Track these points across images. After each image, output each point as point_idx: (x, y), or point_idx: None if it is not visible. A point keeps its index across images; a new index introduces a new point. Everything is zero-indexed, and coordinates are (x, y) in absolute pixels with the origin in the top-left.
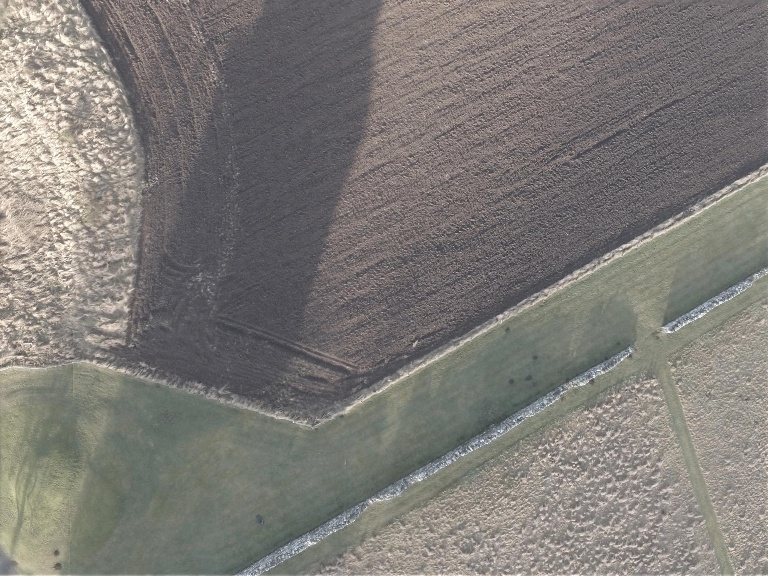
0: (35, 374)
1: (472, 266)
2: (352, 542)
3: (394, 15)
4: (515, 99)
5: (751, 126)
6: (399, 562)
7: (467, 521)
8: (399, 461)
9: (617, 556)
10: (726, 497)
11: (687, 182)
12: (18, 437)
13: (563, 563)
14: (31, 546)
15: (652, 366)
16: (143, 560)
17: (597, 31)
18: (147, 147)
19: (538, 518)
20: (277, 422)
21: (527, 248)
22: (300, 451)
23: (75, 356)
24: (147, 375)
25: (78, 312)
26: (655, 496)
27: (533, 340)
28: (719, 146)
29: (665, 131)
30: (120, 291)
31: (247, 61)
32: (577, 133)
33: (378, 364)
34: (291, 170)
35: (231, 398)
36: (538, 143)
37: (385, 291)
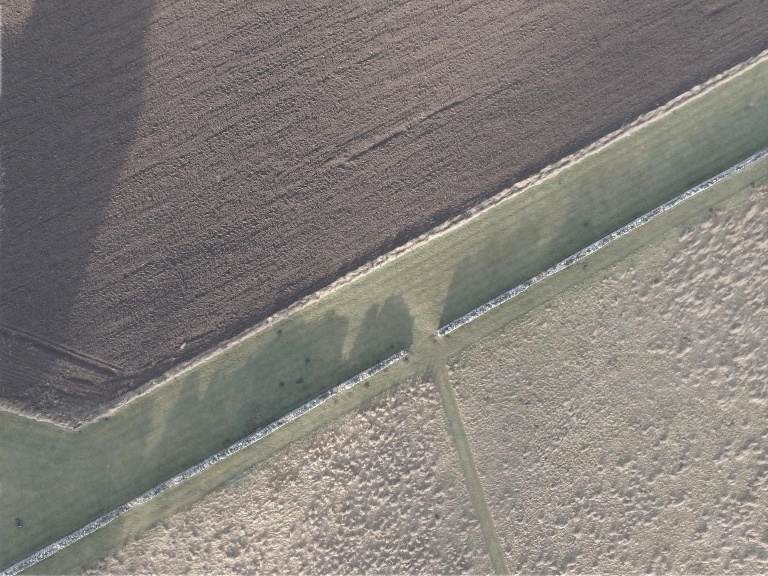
0: None
1: (243, 268)
2: (114, 546)
3: (167, 15)
4: (289, 100)
5: (532, 129)
6: (162, 566)
7: (232, 525)
8: (163, 464)
9: (388, 560)
10: (503, 501)
11: (465, 185)
12: None
13: (332, 567)
14: None
15: (429, 369)
16: None
17: (375, 32)
18: None
19: (306, 522)
20: (40, 424)
21: (299, 250)
22: (63, 454)
23: None
24: None
25: None
26: (429, 500)
27: (306, 343)
28: (499, 149)
29: (443, 133)
30: None
31: (16, 60)
32: (352, 135)
33: (145, 366)
34: (59, 170)
35: None
36: (312, 145)
37: (153, 293)
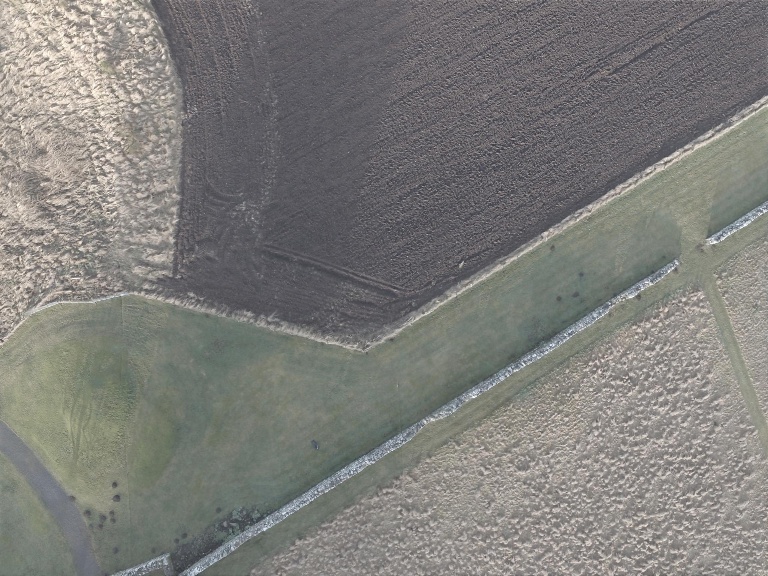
0: (84, 308)
1: (515, 185)
2: (408, 464)
3: None
4: (550, 16)
5: None
6: (455, 482)
7: (521, 439)
8: (451, 382)
9: (672, 469)
10: None
11: (725, 93)
12: (70, 371)
13: (618, 478)
14: (88, 479)
15: (698, 279)
16: (201, 488)
17: None
18: (184, 78)
19: (592, 434)
20: (327, 348)
21: (569, 165)
22: (352, 376)
23: (123, 288)
24: (196, 305)
25: (124, 244)
26: (707, 408)
27: (578, 257)
28: (756, 56)
29: (701, 43)
30: (165, 222)
31: None
32: (614, 48)
33: (425, 286)
34: (329, 96)
35: (280, 325)
36: (575, 59)
37: (429, 213)
